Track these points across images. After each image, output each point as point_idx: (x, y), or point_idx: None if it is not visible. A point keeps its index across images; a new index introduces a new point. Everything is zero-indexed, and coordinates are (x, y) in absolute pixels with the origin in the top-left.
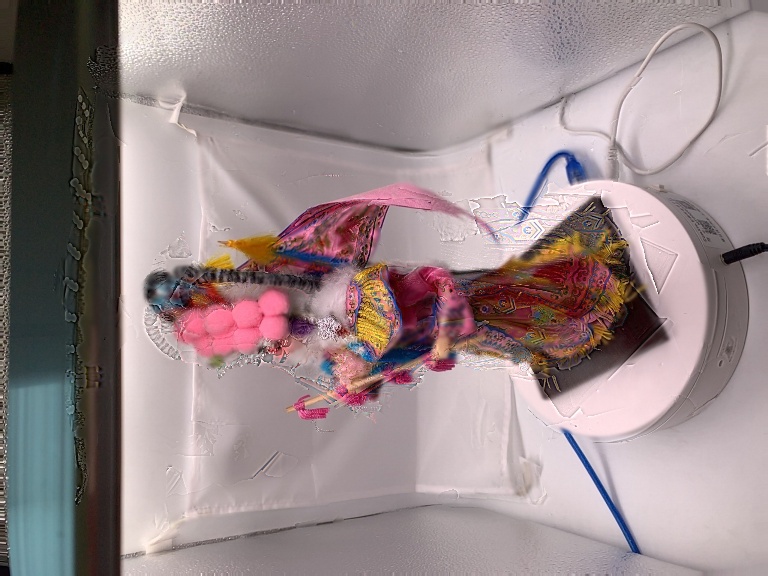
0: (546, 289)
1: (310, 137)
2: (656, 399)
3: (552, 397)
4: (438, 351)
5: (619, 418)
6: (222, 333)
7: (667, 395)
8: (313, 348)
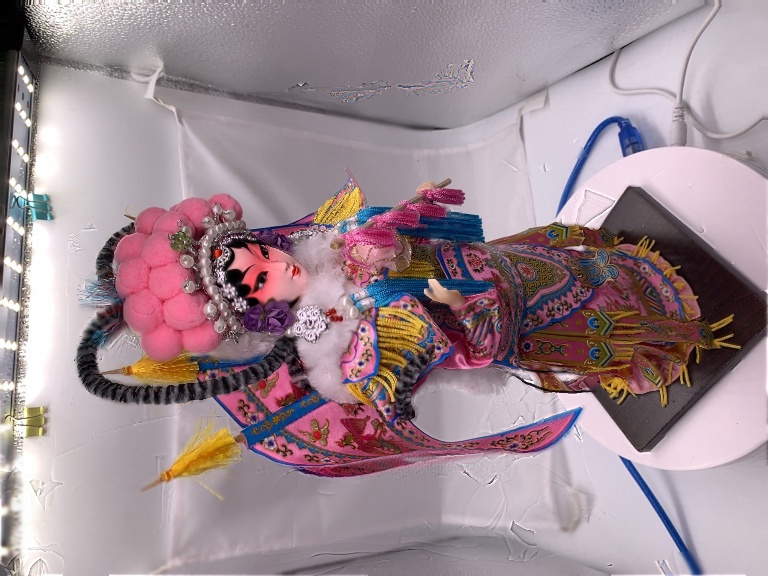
0: (410, 87)
1: (327, 574)
2: (729, 180)
3: (747, 333)
4: (424, 189)
5: (767, 227)
6: (155, 212)
7: (723, 169)
8: (299, 251)
